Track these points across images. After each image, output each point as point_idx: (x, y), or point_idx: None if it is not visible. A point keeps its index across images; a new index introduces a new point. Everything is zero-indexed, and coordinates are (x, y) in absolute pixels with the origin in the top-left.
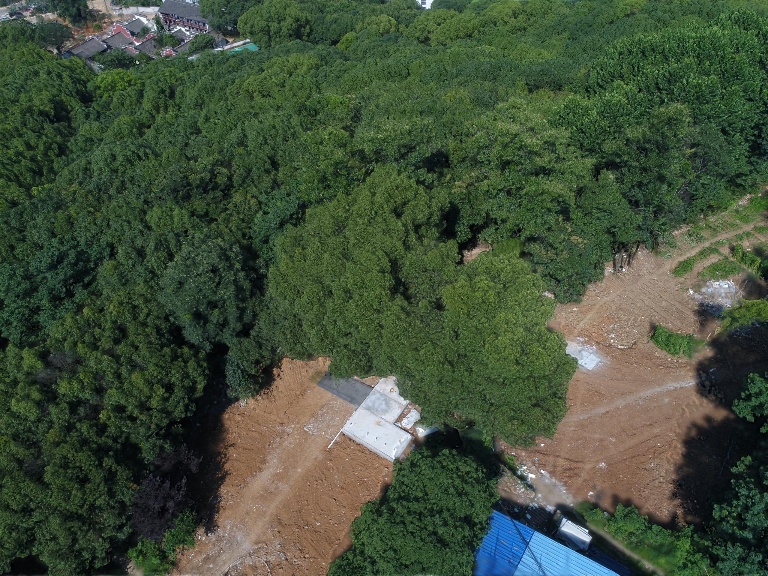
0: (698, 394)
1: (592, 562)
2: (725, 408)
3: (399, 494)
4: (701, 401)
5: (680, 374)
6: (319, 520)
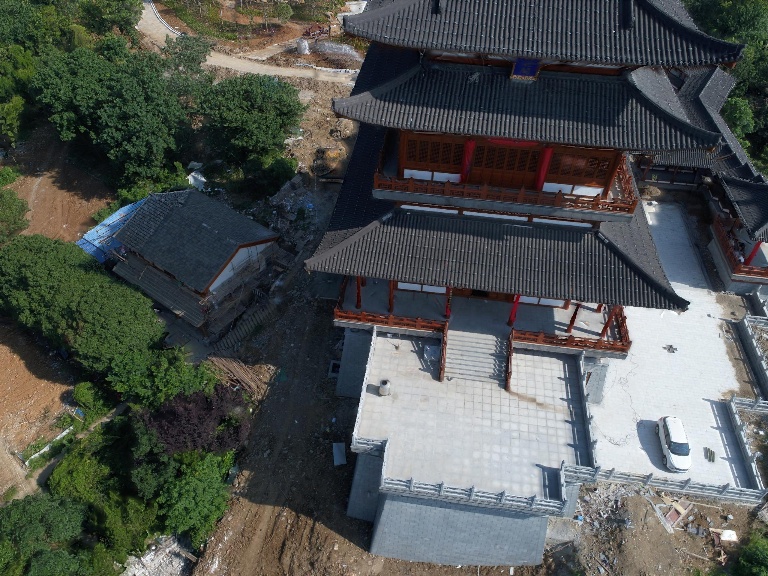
0: (49, 177)
1: (112, 215)
2: (65, 168)
3: (17, 274)
4: (54, 177)
5: (30, 181)
6: (6, 388)
